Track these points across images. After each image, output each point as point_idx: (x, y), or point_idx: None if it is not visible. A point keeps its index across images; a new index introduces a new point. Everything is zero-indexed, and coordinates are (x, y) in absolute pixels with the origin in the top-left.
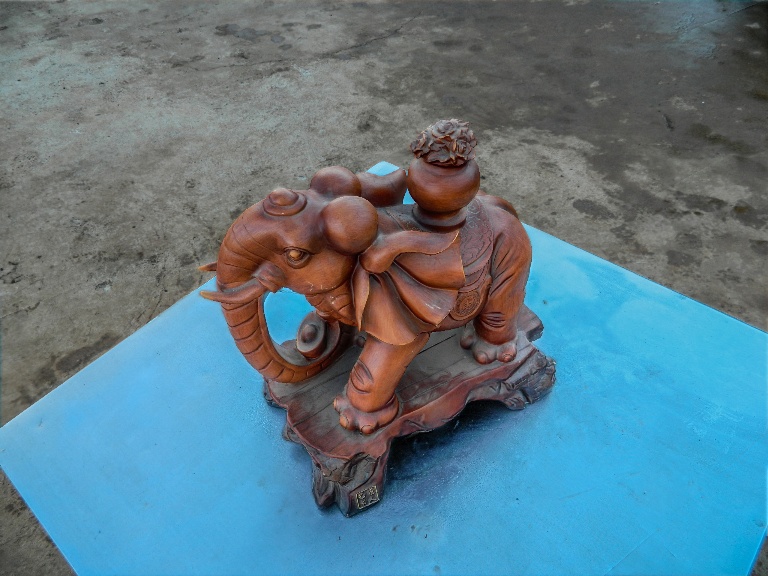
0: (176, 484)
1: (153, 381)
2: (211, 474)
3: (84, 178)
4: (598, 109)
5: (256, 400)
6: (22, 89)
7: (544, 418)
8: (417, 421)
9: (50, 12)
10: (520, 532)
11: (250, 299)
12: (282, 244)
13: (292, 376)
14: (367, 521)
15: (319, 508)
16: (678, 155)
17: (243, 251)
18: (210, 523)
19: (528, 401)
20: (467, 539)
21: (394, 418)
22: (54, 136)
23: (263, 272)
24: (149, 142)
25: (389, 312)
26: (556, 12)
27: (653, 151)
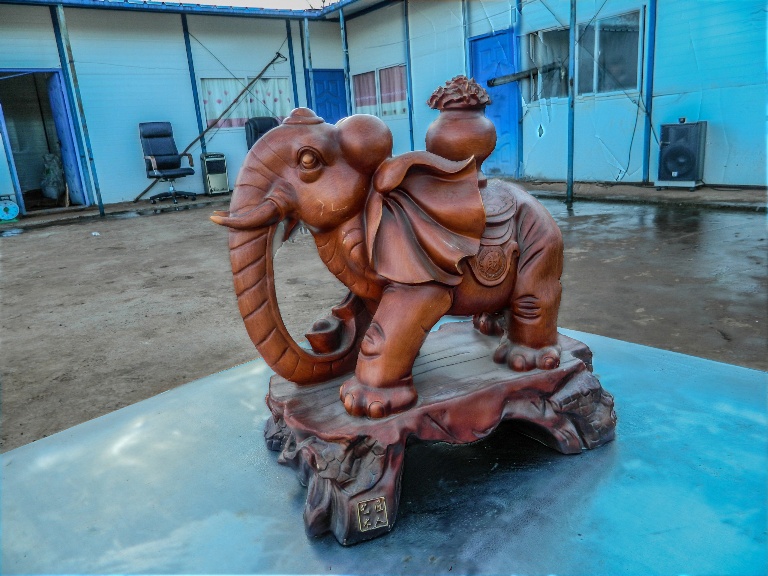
0: (137, 513)
1: (146, 432)
2: (182, 505)
3: (140, 374)
4: (647, 326)
5: (255, 445)
6: (110, 317)
7: (608, 461)
8: (440, 420)
9: (152, 273)
10: (587, 568)
11: (258, 219)
12: (296, 148)
13: (296, 364)
14: (370, 551)
15: (309, 536)
16: (742, 359)
17: (258, 165)
18: (165, 549)
19: (585, 445)
20: (509, 572)
21: (410, 406)
22: (125, 346)
23: (275, 190)
24: (208, 350)
25: (403, 246)
26: (594, 266)
27: (713, 356)
